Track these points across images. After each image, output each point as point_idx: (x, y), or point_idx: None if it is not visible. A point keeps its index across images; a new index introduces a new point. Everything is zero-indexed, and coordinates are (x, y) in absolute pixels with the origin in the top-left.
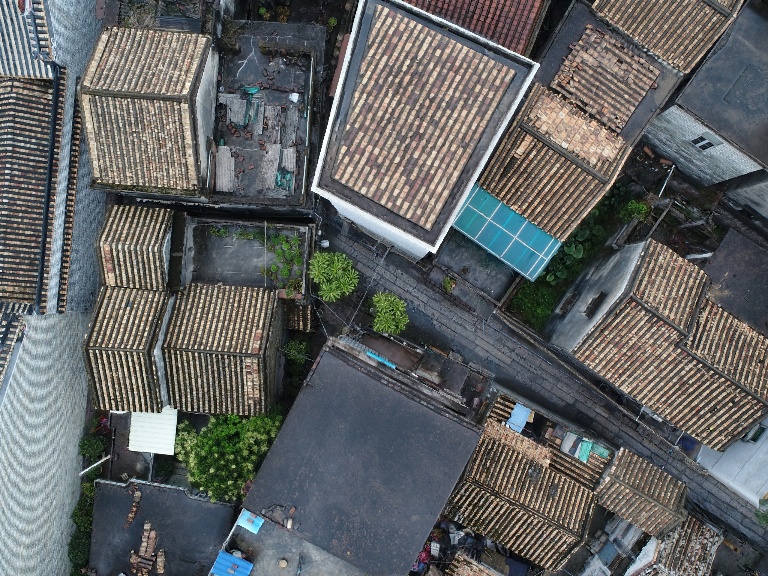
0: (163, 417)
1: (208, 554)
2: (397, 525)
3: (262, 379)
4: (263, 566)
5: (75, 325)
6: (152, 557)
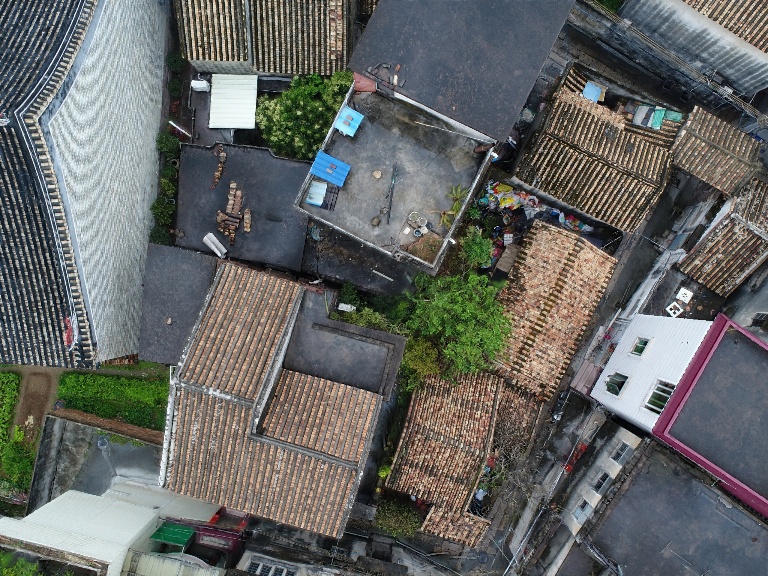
0: (243, 92)
1: (293, 213)
2: (500, 80)
3: (345, 28)
4: (358, 179)
5: (153, 10)
6: (239, 215)
